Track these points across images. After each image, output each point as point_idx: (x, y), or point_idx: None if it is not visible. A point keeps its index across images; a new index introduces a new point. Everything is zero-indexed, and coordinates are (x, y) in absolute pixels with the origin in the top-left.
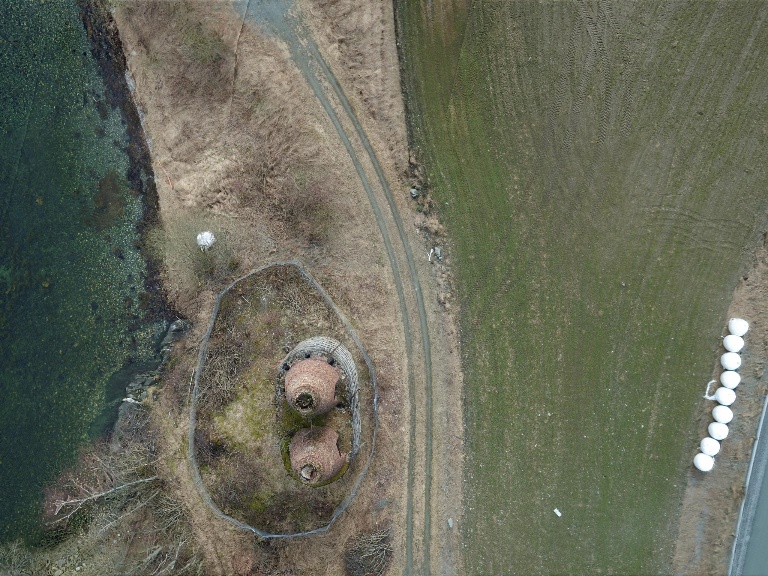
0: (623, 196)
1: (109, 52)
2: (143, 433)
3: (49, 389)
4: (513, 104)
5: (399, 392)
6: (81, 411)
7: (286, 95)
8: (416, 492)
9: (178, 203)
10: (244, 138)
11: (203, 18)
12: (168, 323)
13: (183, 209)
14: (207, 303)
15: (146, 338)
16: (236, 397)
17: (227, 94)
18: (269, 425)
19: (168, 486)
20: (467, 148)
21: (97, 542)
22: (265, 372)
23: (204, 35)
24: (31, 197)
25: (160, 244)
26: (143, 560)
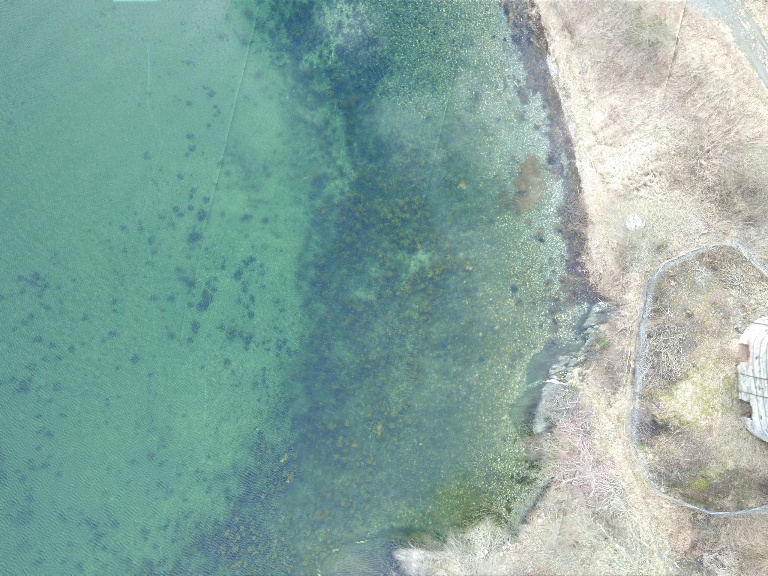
0: None
1: (531, 37)
2: (574, 413)
3: (469, 371)
4: None
5: None
6: (502, 393)
7: (730, 78)
8: None
9: (602, 186)
10: (677, 121)
11: (643, 2)
12: (589, 305)
13: (607, 192)
14: (634, 285)
15: (567, 320)
16: (685, 376)
17: (662, 78)
18: (718, 404)
19: (602, 465)
20: None
21: (520, 522)
22: (715, 351)
23: (643, 19)
24: (450, 182)
25: (582, 227)
26: None
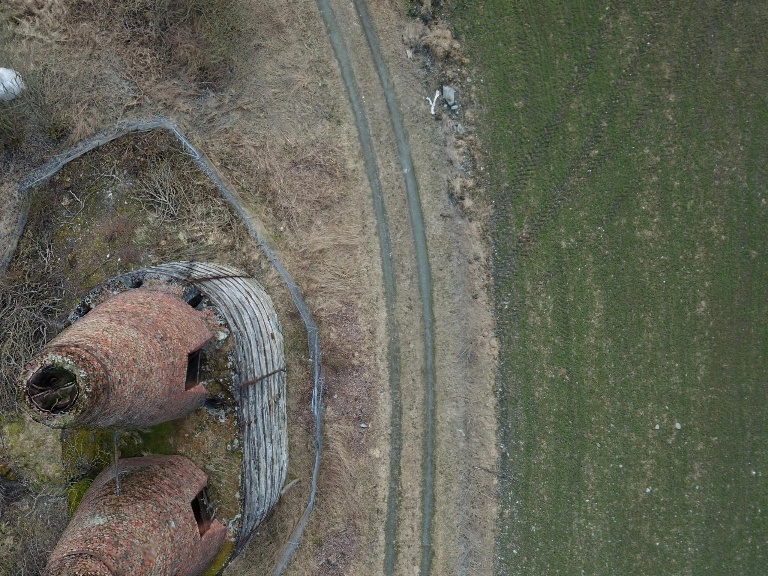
0: None
1: None
2: None
3: None
4: None
5: (368, 377)
6: None
7: None
8: None
9: None
10: None
11: None
12: None
13: None
14: (7, 206)
15: None
16: None
17: None
18: None
19: None
20: None
21: None
22: None
23: None
24: None
25: None
26: None
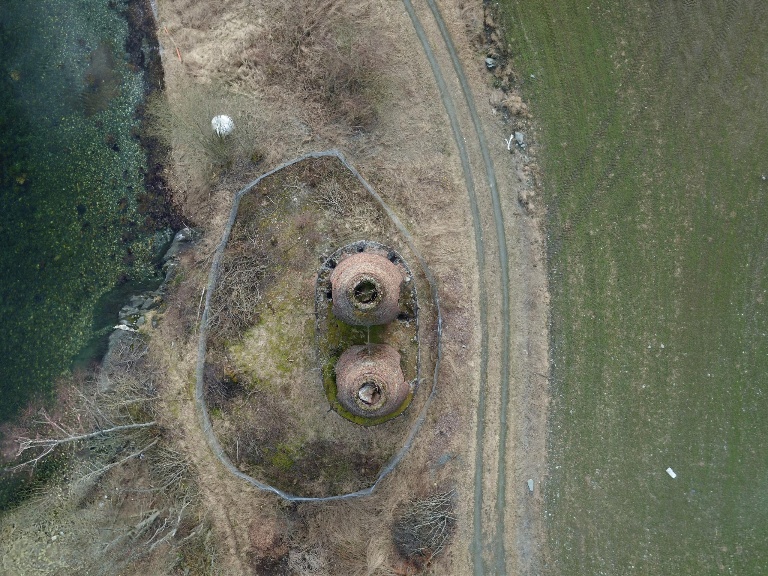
0: (765, 63)
1: None
2: (139, 368)
3: (22, 313)
4: None
5: (467, 316)
6: (62, 341)
7: None
8: (487, 444)
9: (188, 80)
10: None
11: None
12: (173, 232)
13: (194, 88)
14: (222, 206)
15: (145, 250)
16: (258, 320)
17: None
18: (299, 357)
19: (169, 435)
20: (560, 4)
21: (79, 505)
22: (296, 288)
23: None
24: (5, 72)
25: (165, 132)
26: (135, 525)
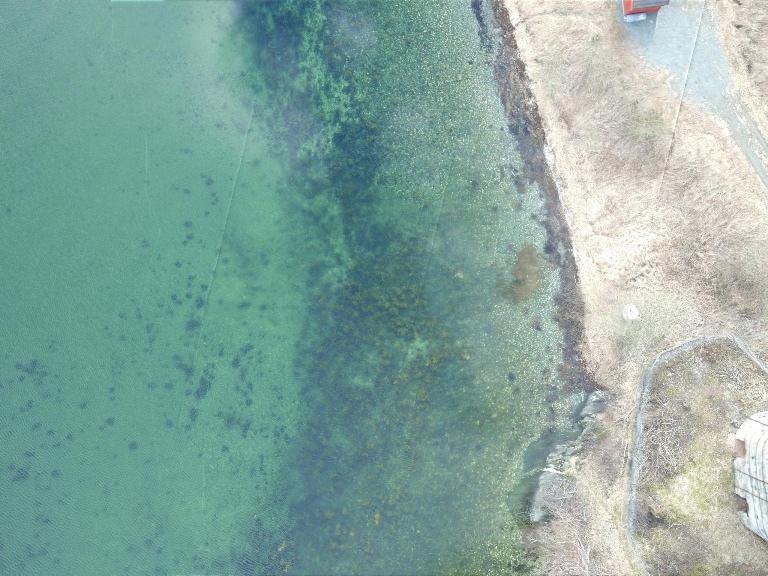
0: None
1: (528, 127)
2: (571, 503)
3: (467, 459)
4: None
5: None
6: (499, 481)
7: (726, 173)
8: None
9: (599, 276)
10: (674, 213)
11: (640, 97)
12: (586, 394)
13: (604, 282)
14: (631, 375)
15: (564, 408)
16: (682, 470)
17: (659, 170)
18: (715, 498)
19: (599, 556)
20: None
21: None
22: (712, 446)
23: (639, 113)
24: (447, 270)
25: (579, 316)
26: None
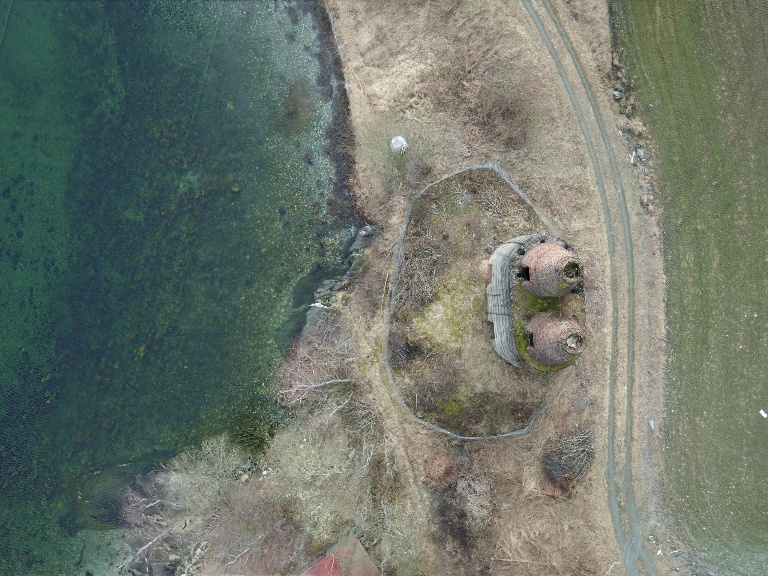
0: None
1: None
2: (334, 337)
3: (236, 294)
4: (722, 5)
5: (602, 293)
6: (268, 316)
7: None
8: (618, 393)
9: (369, 108)
10: (441, 42)
11: None
12: (356, 229)
13: (374, 114)
14: (398, 208)
15: (334, 244)
16: (436, 298)
17: None
18: (469, 326)
19: (360, 389)
20: (673, 49)
21: (283, 447)
22: (466, 273)
23: None
24: (220, 102)
25: (350, 150)
26: None
